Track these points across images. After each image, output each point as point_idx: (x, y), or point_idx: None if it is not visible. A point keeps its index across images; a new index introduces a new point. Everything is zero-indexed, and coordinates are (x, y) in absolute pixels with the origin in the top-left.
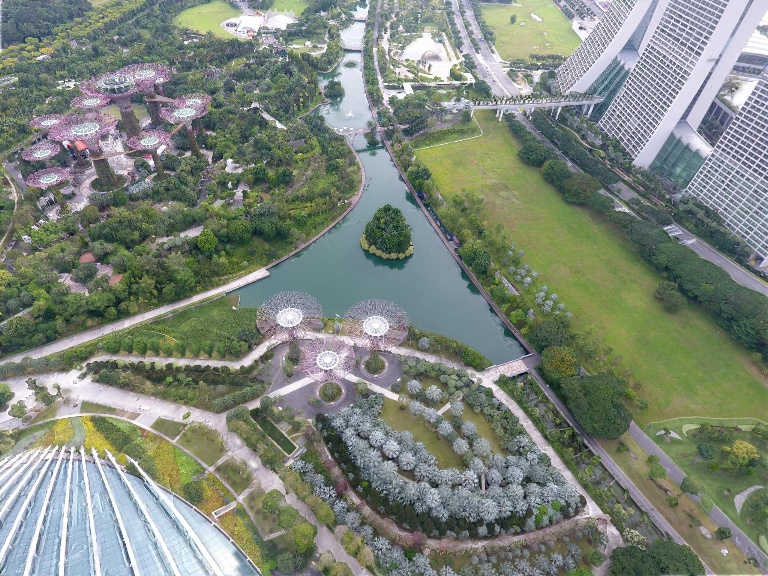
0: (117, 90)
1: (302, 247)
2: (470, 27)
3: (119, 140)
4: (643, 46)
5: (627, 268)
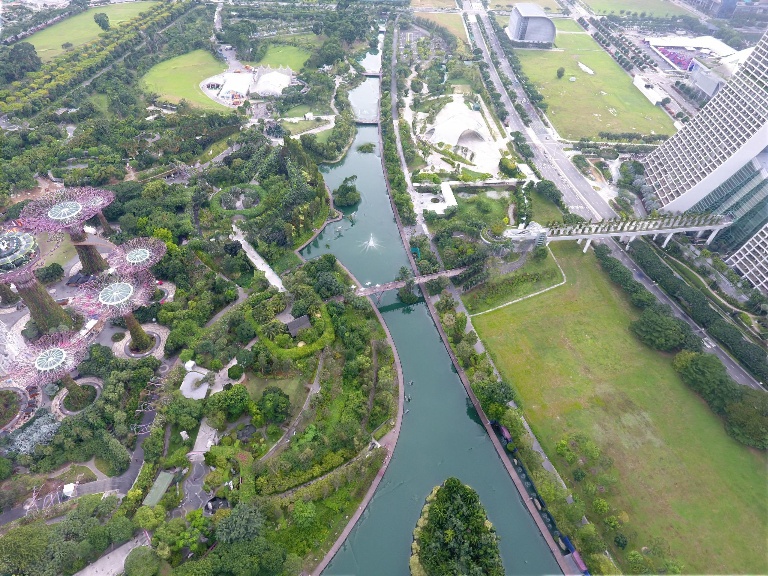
0: (1, 268)
1: None
2: (510, 86)
3: (13, 333)
4: None
5: None
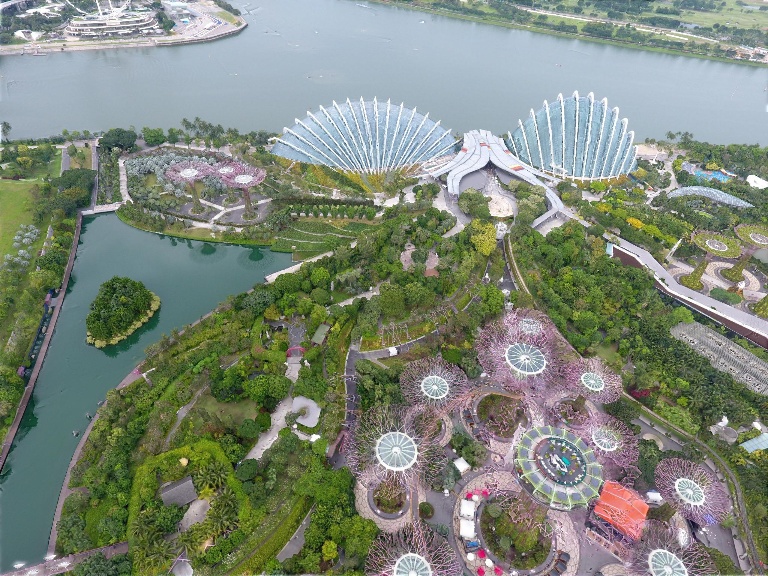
0: None
1: None
2: None
3: None
4: None
5: None
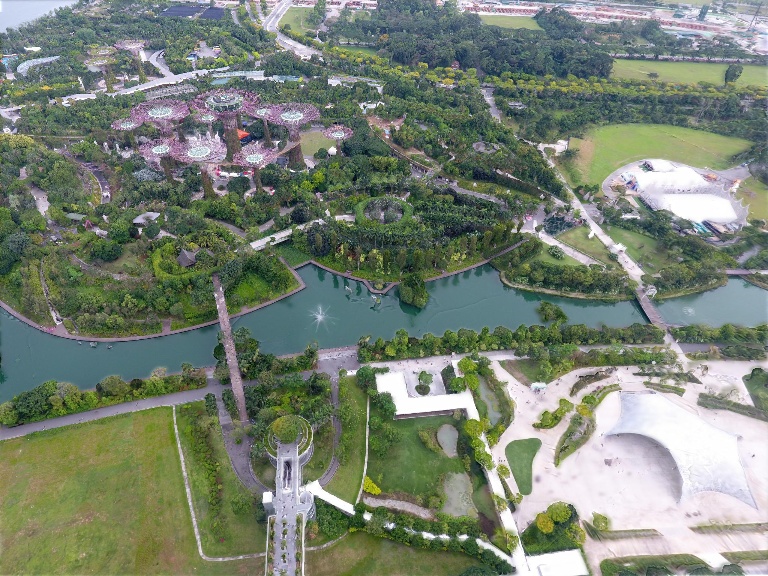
0: None
1: None
2: None
3: None
4: None
5: None
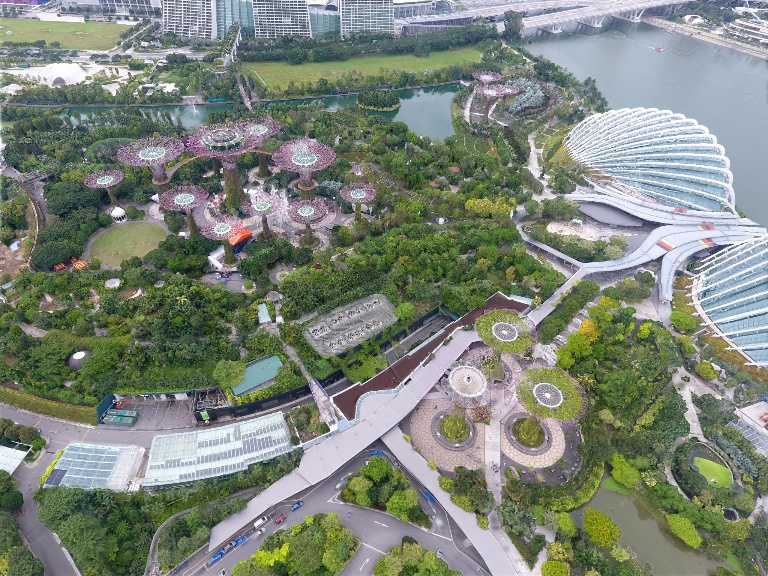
0: None
1: None
2: None
3: (260, 190)
4: None
5: (399, 58)
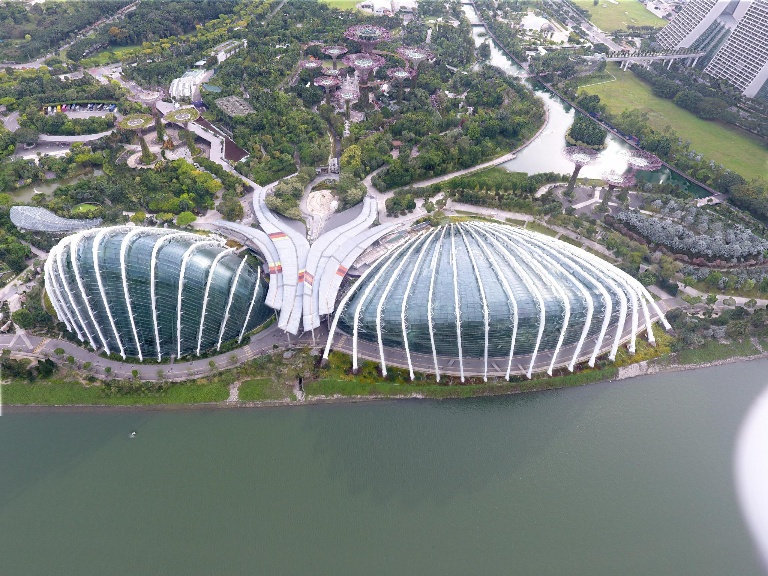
0: None
1: (528, 143)
2: (564, 8)
3: None
4: (737, 11)
5: (761, 154)
